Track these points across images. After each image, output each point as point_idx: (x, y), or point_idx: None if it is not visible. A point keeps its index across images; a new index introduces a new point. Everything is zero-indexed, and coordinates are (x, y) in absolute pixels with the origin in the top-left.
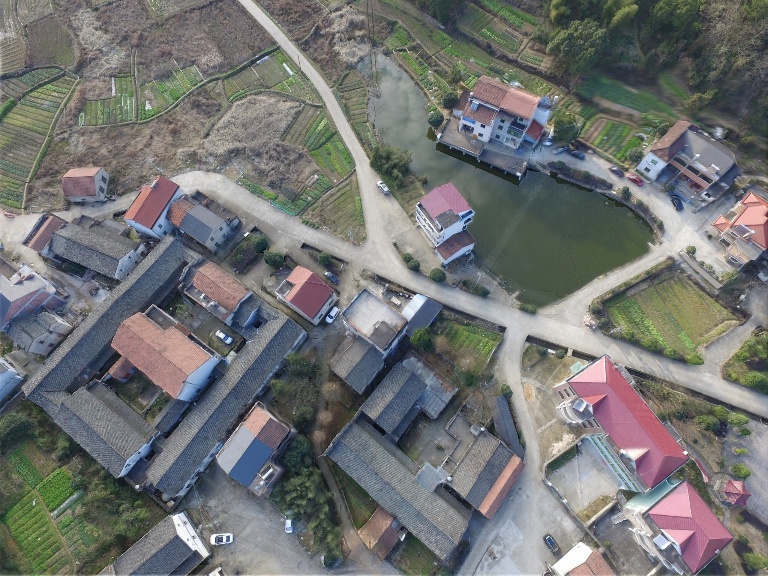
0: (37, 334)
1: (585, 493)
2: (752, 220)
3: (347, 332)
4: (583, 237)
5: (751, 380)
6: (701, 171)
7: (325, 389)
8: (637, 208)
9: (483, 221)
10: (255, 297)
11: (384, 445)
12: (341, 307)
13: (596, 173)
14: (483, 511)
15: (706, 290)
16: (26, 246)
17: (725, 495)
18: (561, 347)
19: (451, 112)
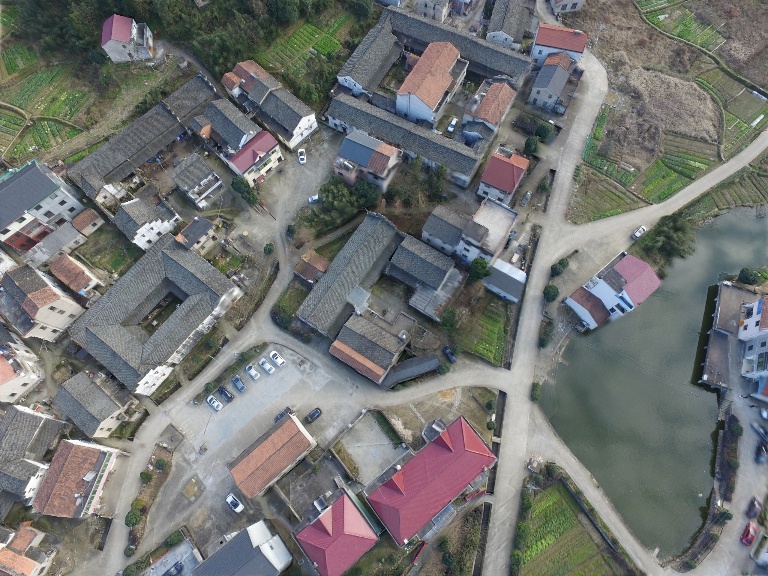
0: None
1: (359, 450)
2: None
3: None
4: (642, 460)
5: None
6: None
7: (422, 211)
8: (705, 535)
9: (625, 325)
10: (491, 134)
11: (381, 260)
12: None
13: (741, 480)
14: (335, 343)
15: None
16: None
17: None
18: (500, 430)
19: (767, 294)
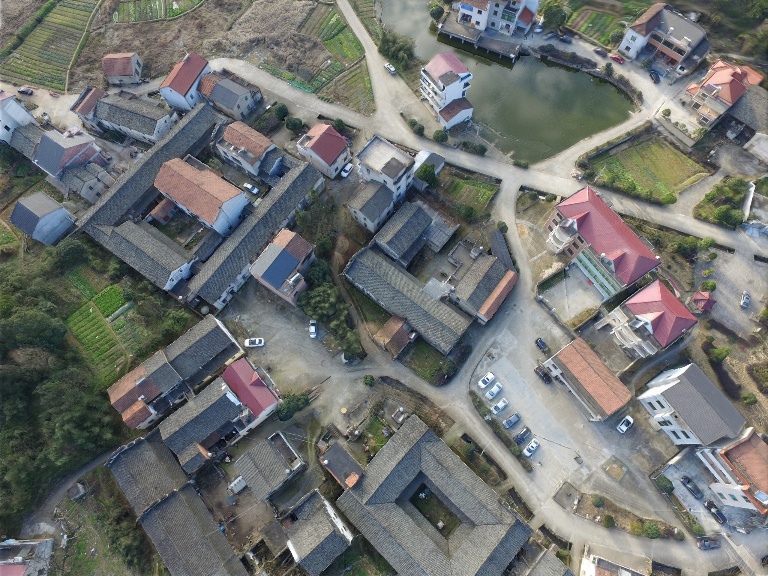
0: (87, 179)
1: (572, 307)
2: (719, 80)
3: (361, 180)
4: (570, 107)
5: (718, 212)
6: (675, 44)
7: (342, 230)
8: (619, 82)
9: (480, 85)
10: (279, 150)
11: None
12: (354, 165)
13: (582, 54)
14: (482, 312)
15: (680, 148)
16: (73, 112)
17: (694, 305)
18: None
19: (451, 6)
